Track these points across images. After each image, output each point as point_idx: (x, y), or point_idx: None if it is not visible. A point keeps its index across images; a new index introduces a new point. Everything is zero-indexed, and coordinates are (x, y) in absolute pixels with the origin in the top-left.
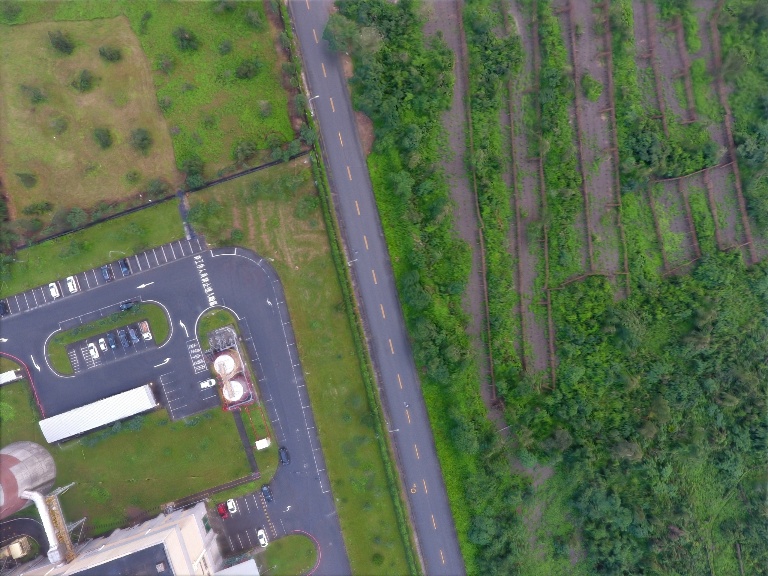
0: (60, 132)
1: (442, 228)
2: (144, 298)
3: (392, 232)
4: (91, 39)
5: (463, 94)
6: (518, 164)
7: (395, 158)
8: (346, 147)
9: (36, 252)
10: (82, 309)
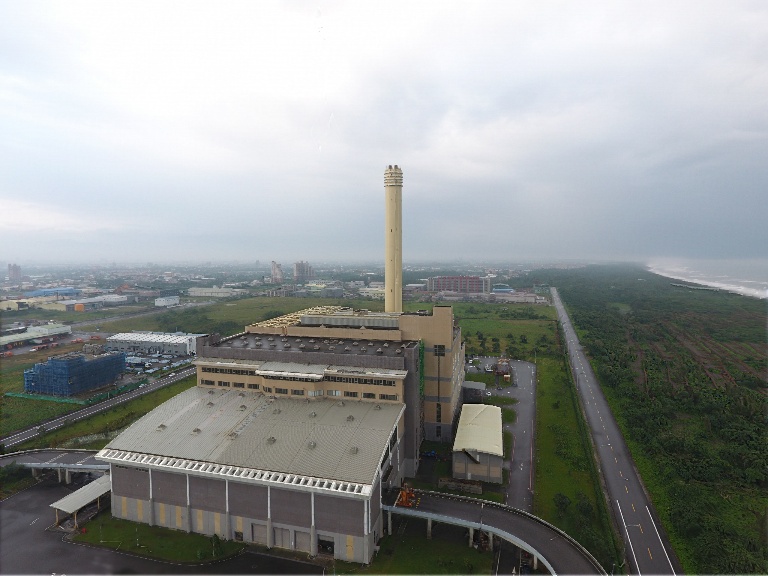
0: None
1: None
2: None
3: None
4: None
5: None
6: None
7: None
8: None
9: None
10: None
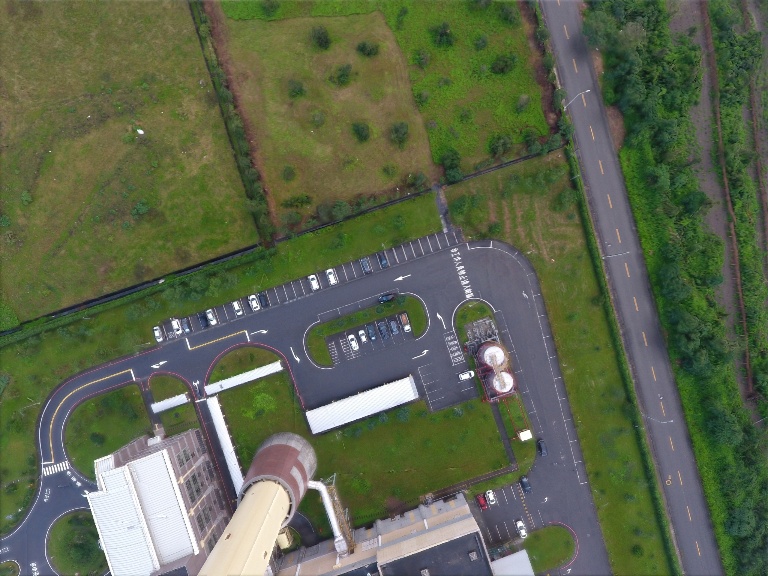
0: (318, 126)
1: (695, 221)
2: (402, 290)
3: (645, 225)
4: (347, 34)
5: (709, 89)
6: (761, 159)
7: (649, 152)
8: (598, 141)
9: (295, 245)
10: (341, 301)
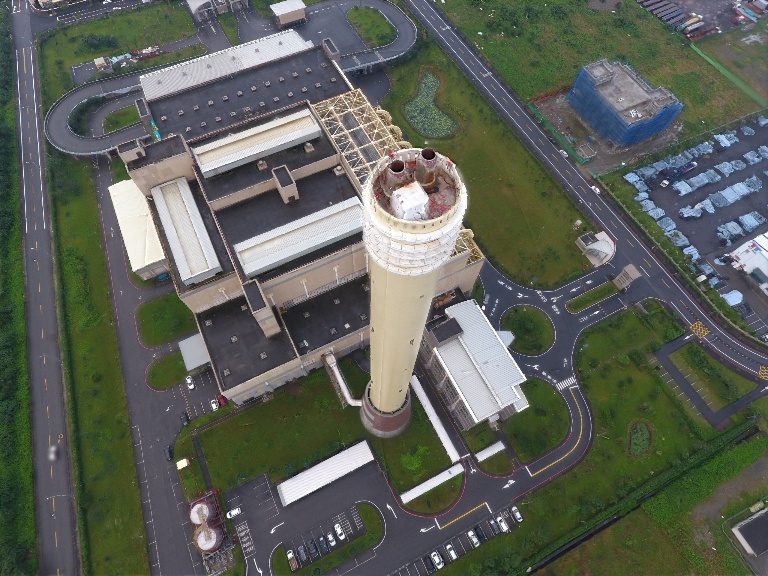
0: None
1: None
2: None
3: None
4: None
5: None
6: None
7: None
8: None
9: None
10: (356, 574)
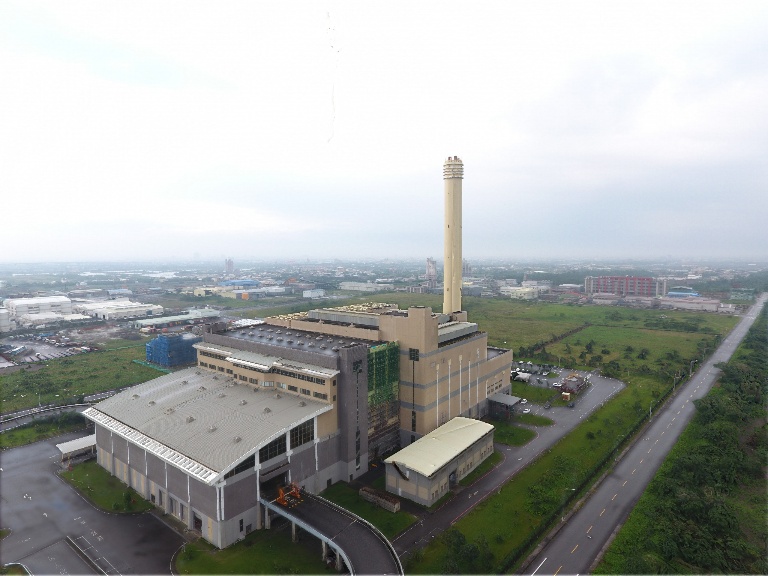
0: None
1: None
2: None
3: None
4: None
5: None
6: None
7: None
8: None
9: None
10: None
